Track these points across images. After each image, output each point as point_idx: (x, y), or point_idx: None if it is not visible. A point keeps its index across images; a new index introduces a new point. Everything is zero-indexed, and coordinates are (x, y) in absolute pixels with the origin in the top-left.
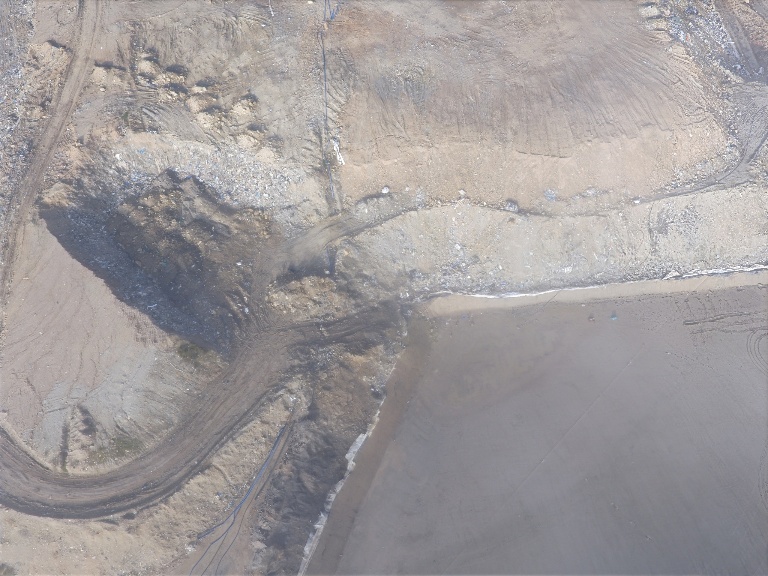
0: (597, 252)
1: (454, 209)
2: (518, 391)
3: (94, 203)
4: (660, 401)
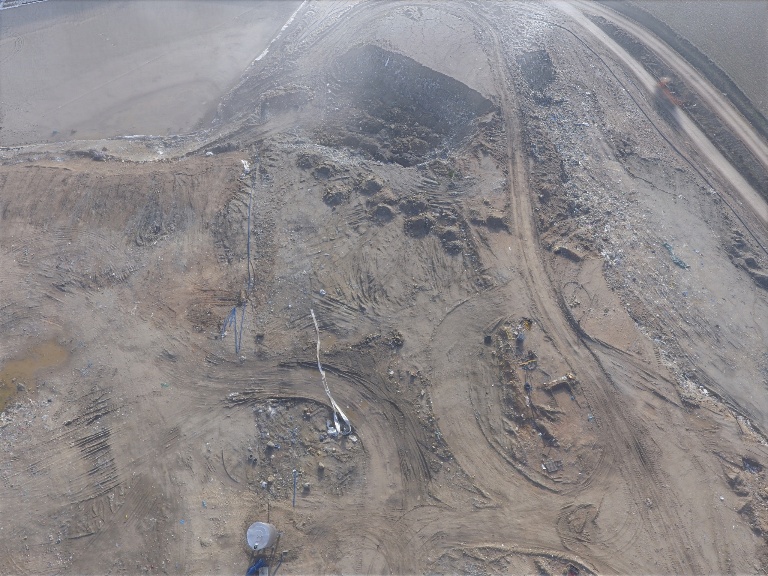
0: None
1: None
2: (150, 93)
3: None
4: (53, 87)
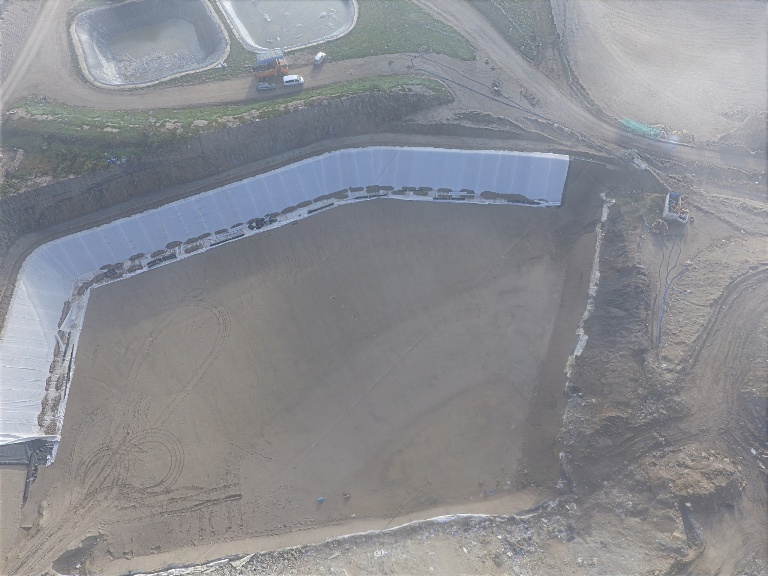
0: None
1: None
2: (431, 410)
3: None
4: (294, 406)
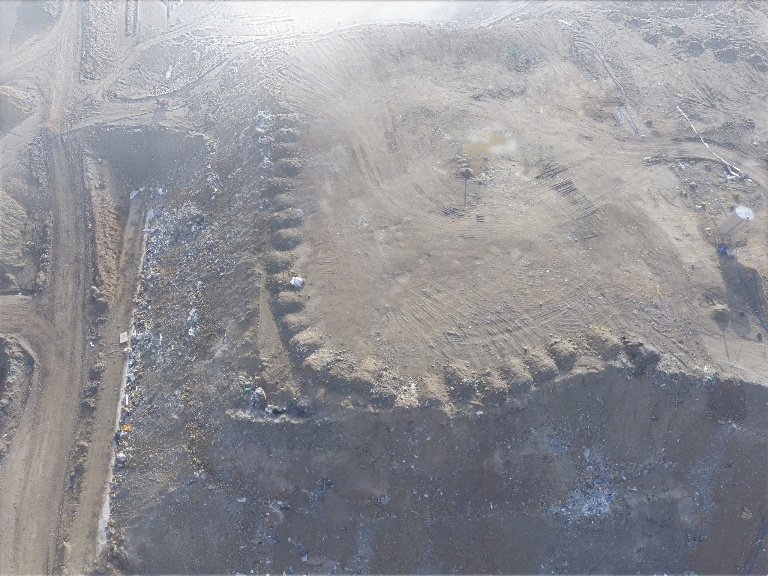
0: None
1: None
2: None
3: (715, 4)
4: None
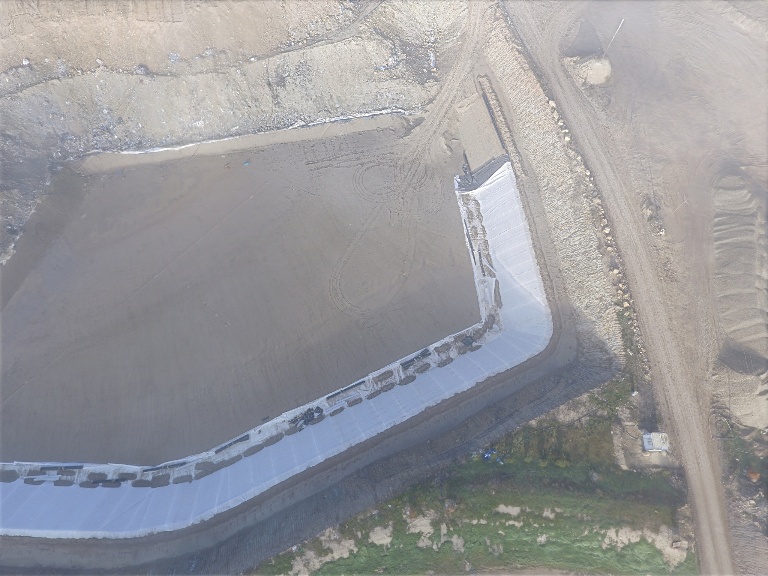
0: (222, 106)
1: (95, 77)
2: (150, 226)
3: None
4: (267, 224)
